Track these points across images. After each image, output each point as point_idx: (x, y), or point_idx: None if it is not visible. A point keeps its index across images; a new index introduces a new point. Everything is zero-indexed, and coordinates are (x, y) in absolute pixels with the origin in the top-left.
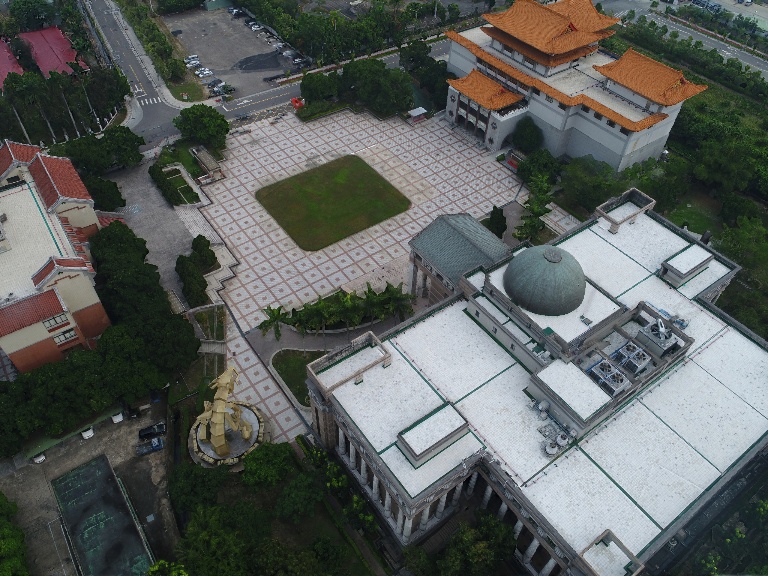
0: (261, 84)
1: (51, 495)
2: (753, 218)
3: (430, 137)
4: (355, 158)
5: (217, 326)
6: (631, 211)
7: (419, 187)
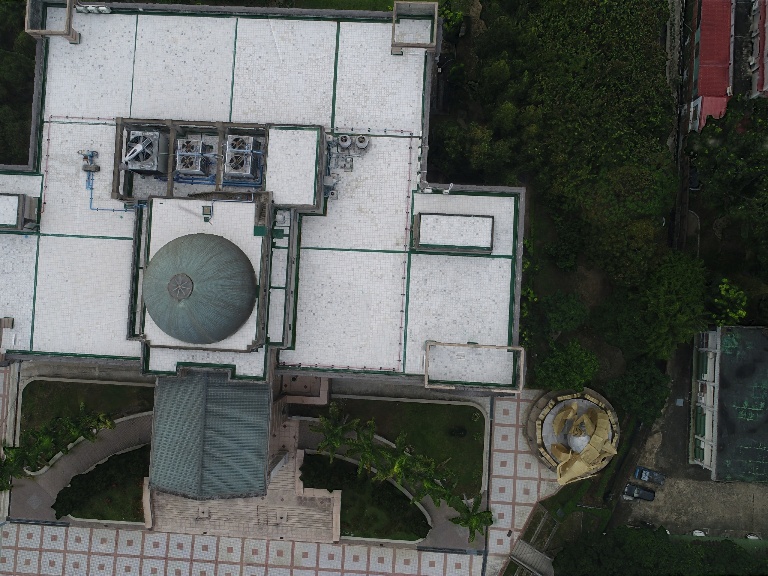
0: None
1: (754, 490)
2: None
3: None
4: None
5: None
6: None
7: None
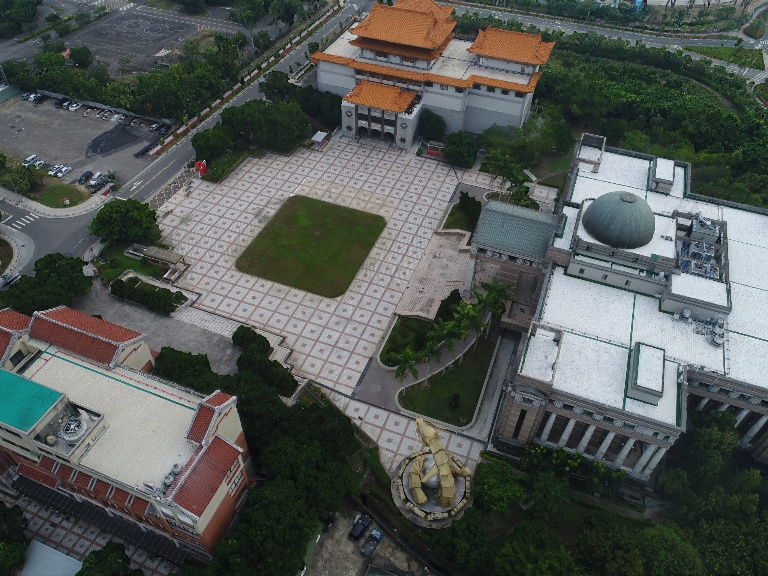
0: (136, 161)
1: None
2: (634, 131)
3: (345, 155)
4: (299, 198)
5: (324, 402)
6: (590, 152)
7: (377, 201)
